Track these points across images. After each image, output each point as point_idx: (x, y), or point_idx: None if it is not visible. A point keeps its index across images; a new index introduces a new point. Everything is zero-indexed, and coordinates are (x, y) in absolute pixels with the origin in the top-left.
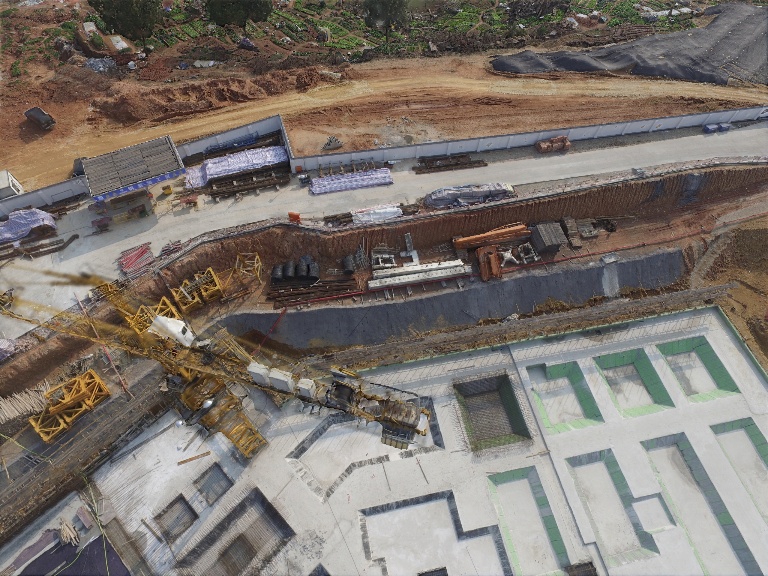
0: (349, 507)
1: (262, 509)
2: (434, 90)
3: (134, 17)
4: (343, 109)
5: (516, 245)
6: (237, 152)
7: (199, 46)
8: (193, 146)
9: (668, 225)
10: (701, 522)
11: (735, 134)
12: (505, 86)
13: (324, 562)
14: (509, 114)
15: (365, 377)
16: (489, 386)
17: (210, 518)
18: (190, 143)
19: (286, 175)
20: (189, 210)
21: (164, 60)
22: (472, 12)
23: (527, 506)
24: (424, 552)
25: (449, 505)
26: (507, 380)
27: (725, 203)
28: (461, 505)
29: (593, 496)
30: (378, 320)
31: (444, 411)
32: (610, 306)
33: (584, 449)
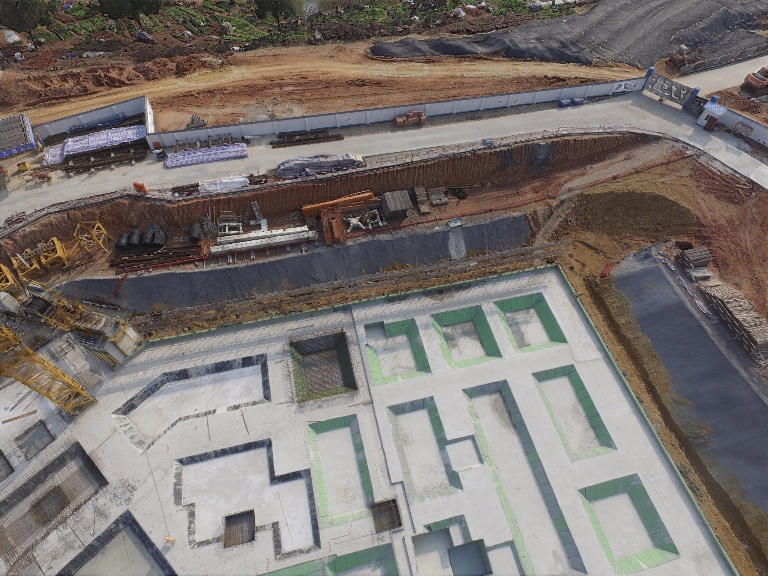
0: (166, 457)
1: (82, 463)
2: (310, 74)
3: (13, 8)
4: (216, 92)
5: None
6: (99, 131)
7: (94, 39)
8: (55, 126)
9: (517, 192)
10: (511, 461)
11: (588, 107)
12: (380, 69)
13: (132, 508)
14: (376, 93)
15: (204, 338)
16: (327, 344)
17: (25, 471)
18: (50, 122)
19: (144, 151)
20: (42, 184)
21: (53, 51)
22: (379, 8)
23: (345, 452)
24: (235, 497)
25: (267, 453)
26: (344, 337)
27: (573, 171)
28: (277, 452)
29: (411, 441)
30: (220, 284)
31: (276, 367)
32: (442, 264)
33: (407, 397)
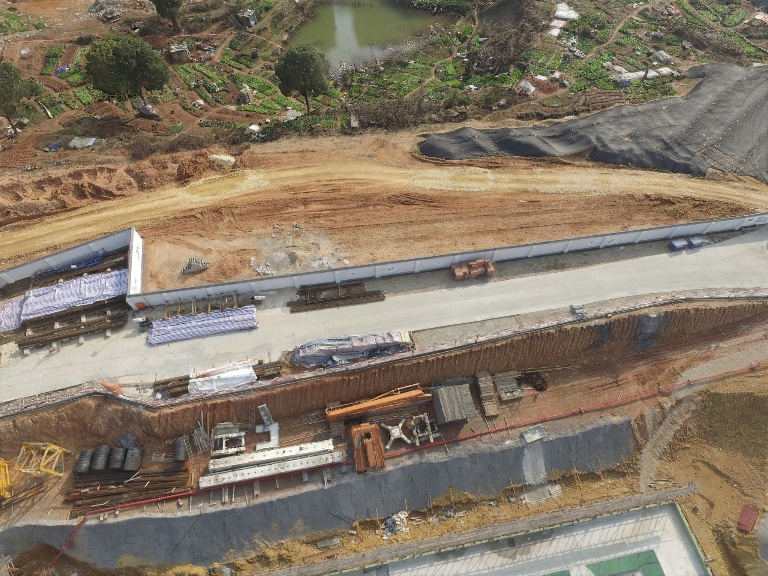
0: None
1: None
2: (342, 183)
3: None
4: (224, 211)
5: (412, 413)
6: (70, 279)
7: (88, 115)
8: (14, 272)
9: (616, 381)
10: None
11: (709, 252)
12: (431, 177)
13: None
14: (427, 220)
15: None
16: None
17: None
18: (8, 270)
19: (123, 314)
20: None
21: (36, 138)
22: (425, 63)
23: None
24: None
25: None
26: None
27: (692, 350)
28: None
29: None
30: (211, 531)
31: None
32: (519, 524)
33: None
